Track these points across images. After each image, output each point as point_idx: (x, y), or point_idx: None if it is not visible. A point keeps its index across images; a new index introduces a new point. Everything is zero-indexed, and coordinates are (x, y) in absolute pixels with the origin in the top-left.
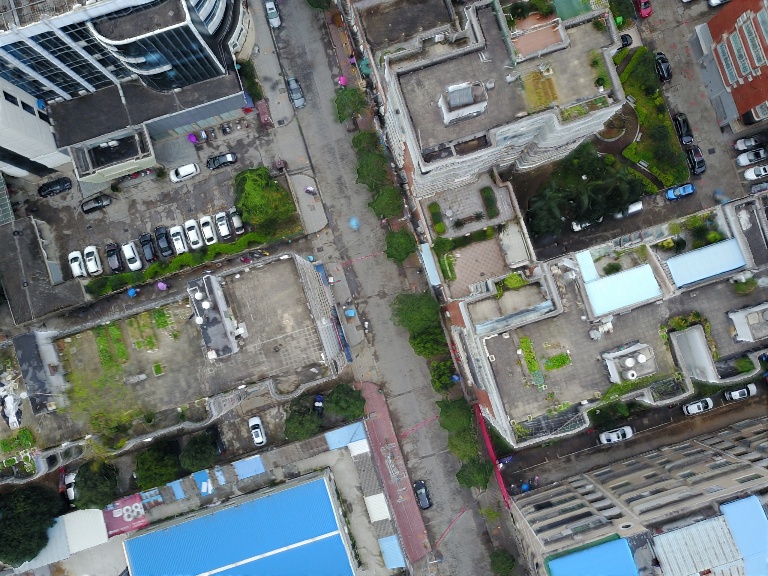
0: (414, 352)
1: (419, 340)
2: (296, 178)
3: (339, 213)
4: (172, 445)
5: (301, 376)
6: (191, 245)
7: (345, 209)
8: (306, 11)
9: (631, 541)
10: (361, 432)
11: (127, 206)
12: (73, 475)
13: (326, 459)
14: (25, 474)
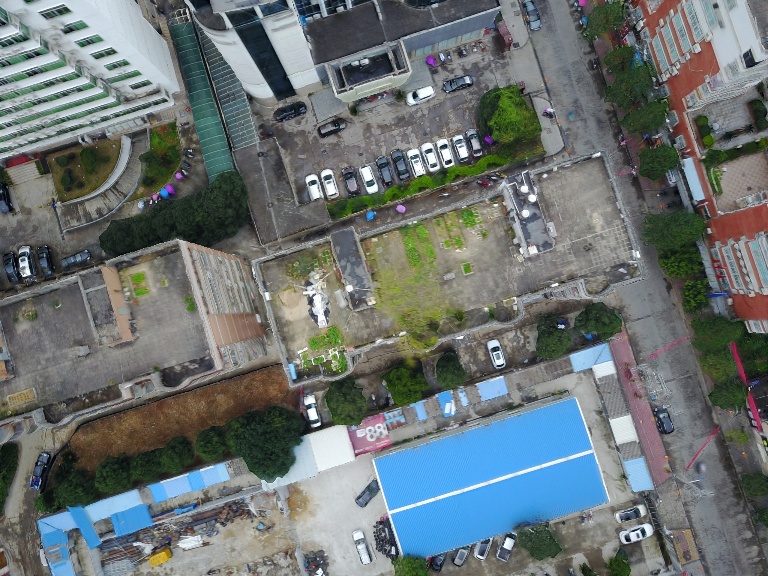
0: (653, 276)
1: (673, 259)
2: None
3: (575, 136)
4: (416, 365)
5: (609, 276)
6: (429, 168)
7: (581, 132)
8: None
9: None
10: (607, 354)
11: (362, 130)
12: (312, 396)
13: (564, 383)
14: (332, 373)
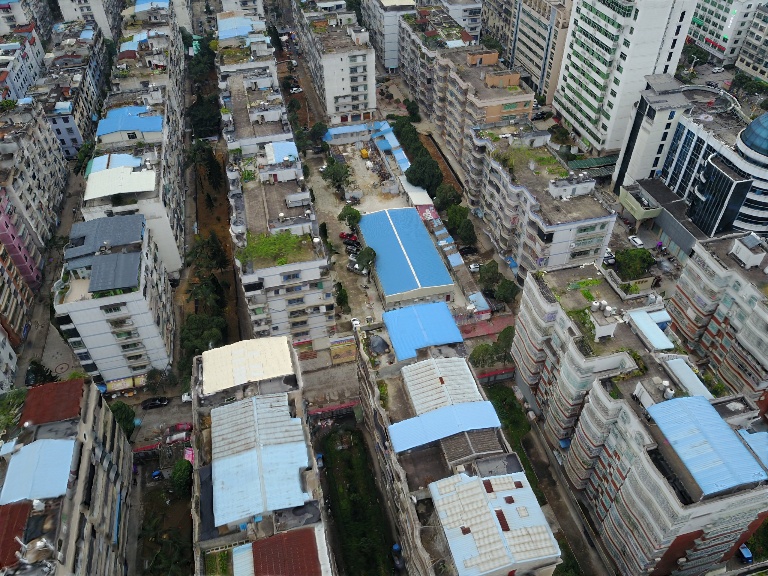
0: None
1: None
2: None
3: None
4: None
5: (543, 220)
6: None
7: None
8: None
9: (460, 347)
10: (483, 309)
11: None
12: None
13: (459, 300)
14: None
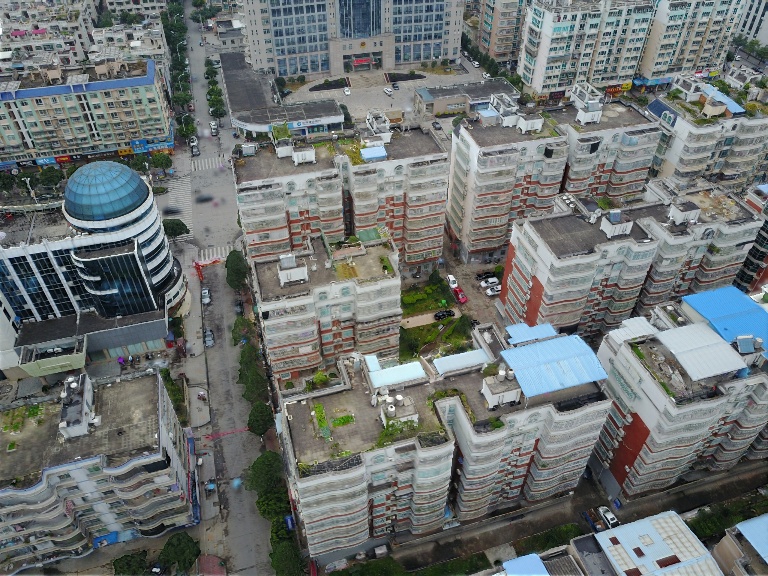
0: (264, 528)
1: (264, 498)
2: (193, 389)
3: (221, 414)
4: None
5: None
6: None
7: (227, 412)
8: (229, 297)
9: None
10: None
11: None
12: None
13: None
14: None
